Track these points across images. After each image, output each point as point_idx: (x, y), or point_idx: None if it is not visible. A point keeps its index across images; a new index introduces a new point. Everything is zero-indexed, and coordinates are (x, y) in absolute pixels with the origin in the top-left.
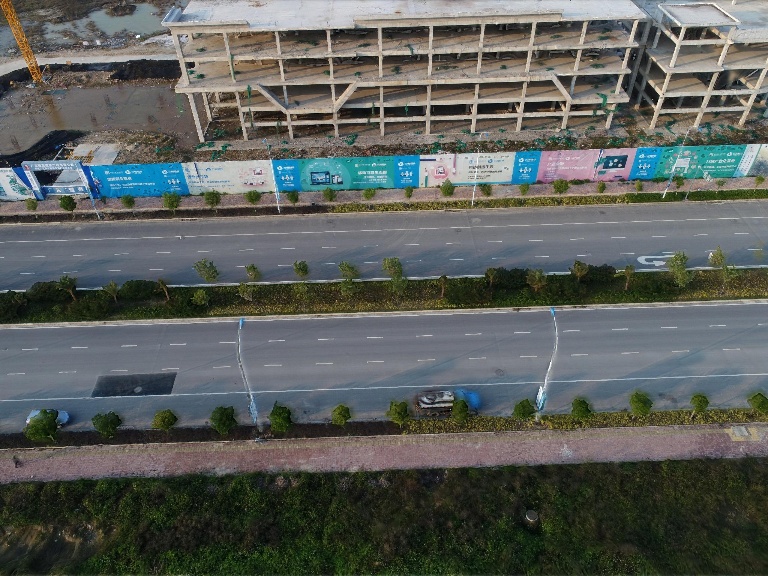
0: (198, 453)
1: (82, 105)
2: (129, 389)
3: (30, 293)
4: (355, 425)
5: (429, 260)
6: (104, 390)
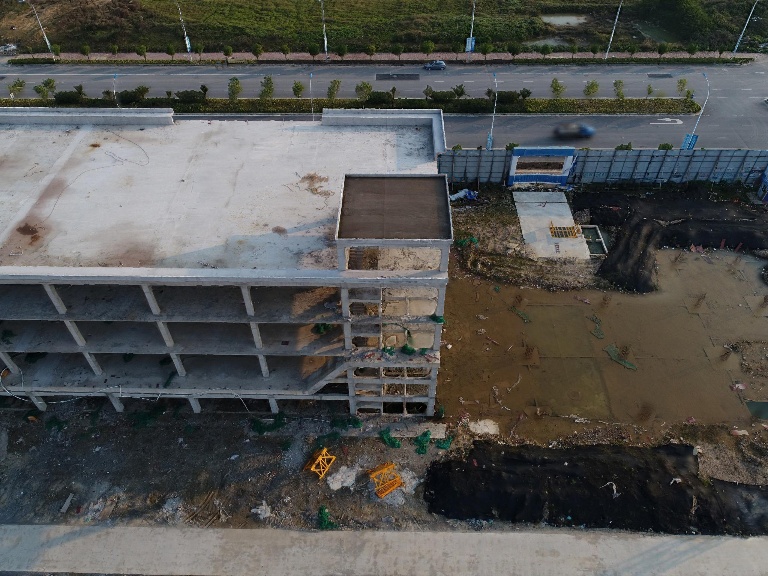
0: (355, 58)
1: (675, 362)
2: (400, 76)
3: (489, 100)
4: (280, 63)
5: None
6: (414, 76)
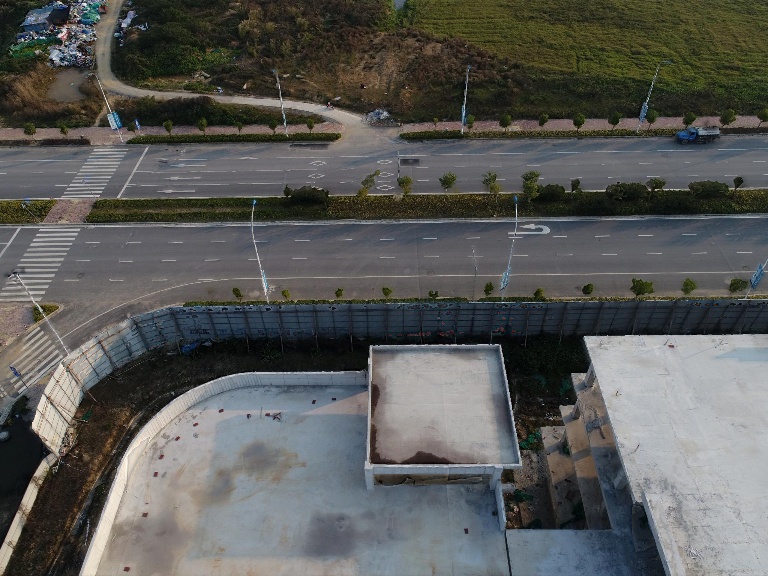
0: None
1: None
2: None
3: None
4: (750, 132)
5: (761, 233)
6: None
